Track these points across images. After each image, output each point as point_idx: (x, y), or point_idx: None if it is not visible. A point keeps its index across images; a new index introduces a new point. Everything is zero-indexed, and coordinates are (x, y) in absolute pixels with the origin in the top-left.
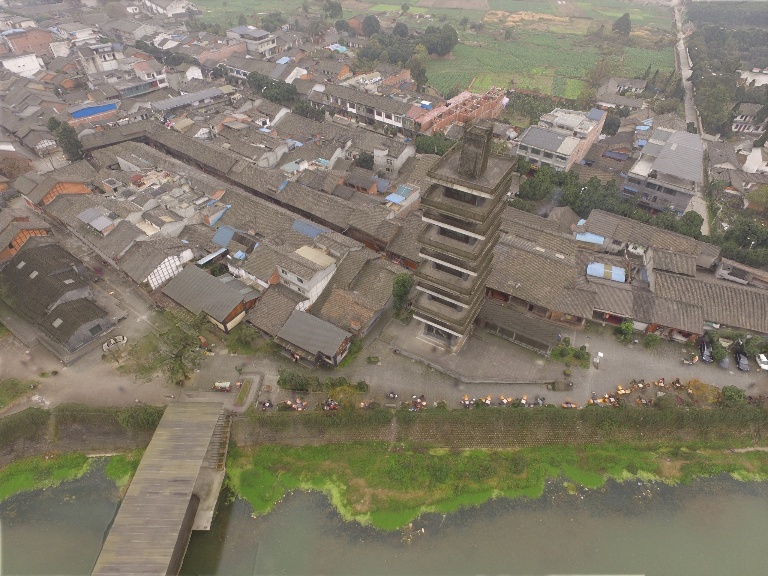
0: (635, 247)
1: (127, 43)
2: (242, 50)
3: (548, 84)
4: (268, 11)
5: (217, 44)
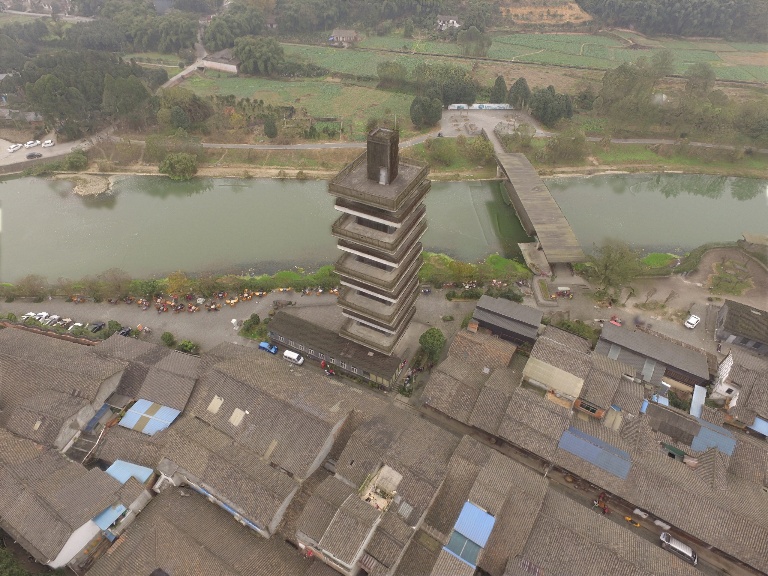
0: None
1: None
2: None
3: None
4: None
5: None
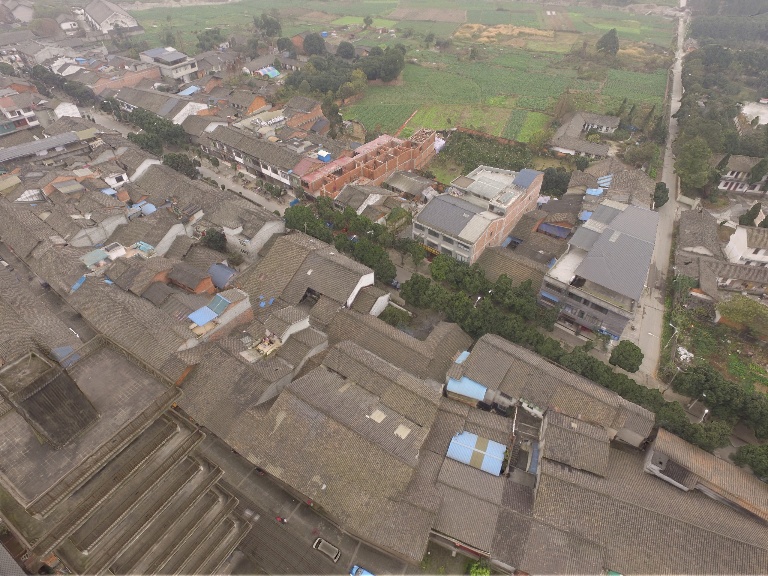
0: (530, 406)
1: (32, 67)
2: (155, 76)
3: (503, 119)
4: (218, 25)
5: (121, 70)
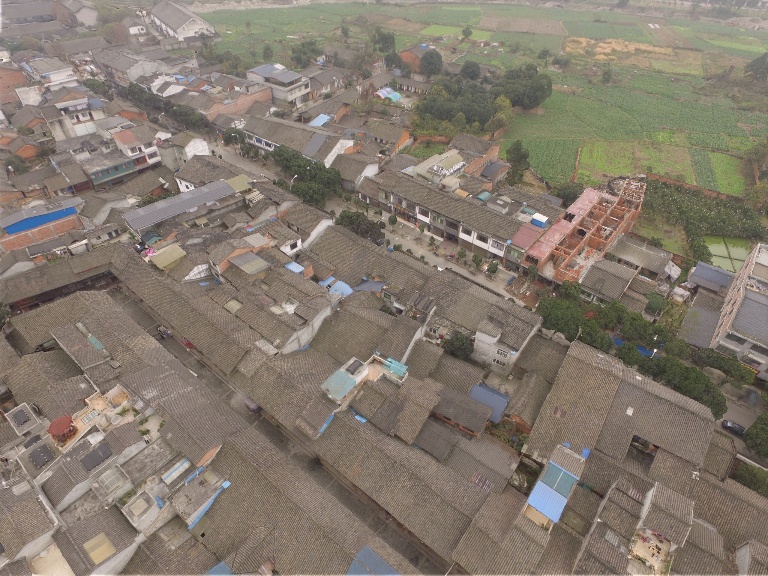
0: None
1: (120, 83)
2: (266, 98)
3: (685, 161)
4: (299, 33)
5: (233, 92)
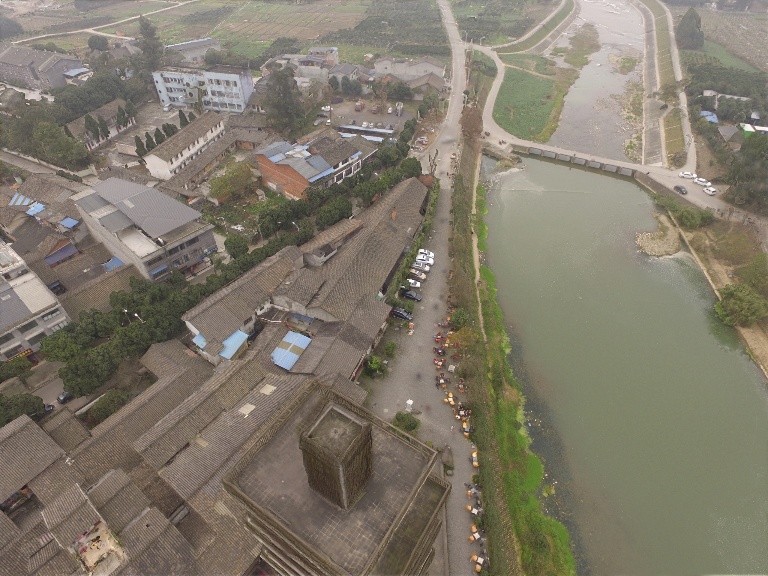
0: (261, 308)
1: None
2: None
3: None
4: None
5: None
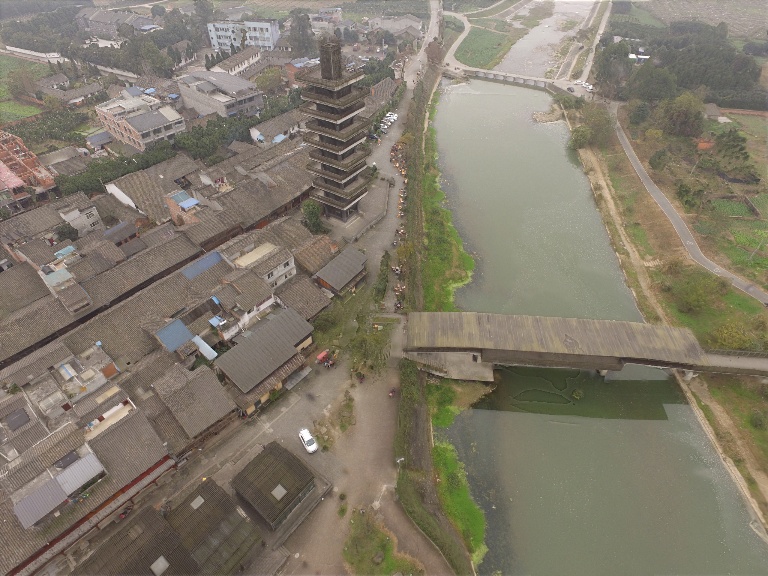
0: (293, 128)
1: None
2: None
3: None
4: None
5: None
